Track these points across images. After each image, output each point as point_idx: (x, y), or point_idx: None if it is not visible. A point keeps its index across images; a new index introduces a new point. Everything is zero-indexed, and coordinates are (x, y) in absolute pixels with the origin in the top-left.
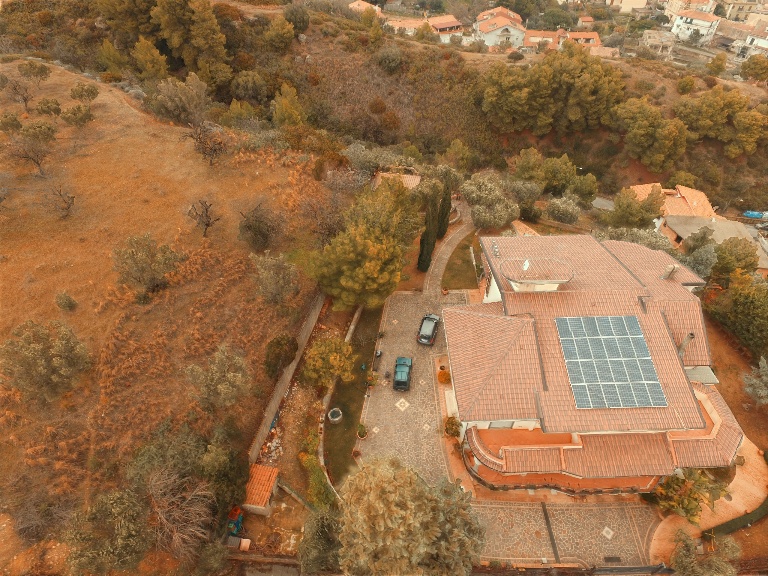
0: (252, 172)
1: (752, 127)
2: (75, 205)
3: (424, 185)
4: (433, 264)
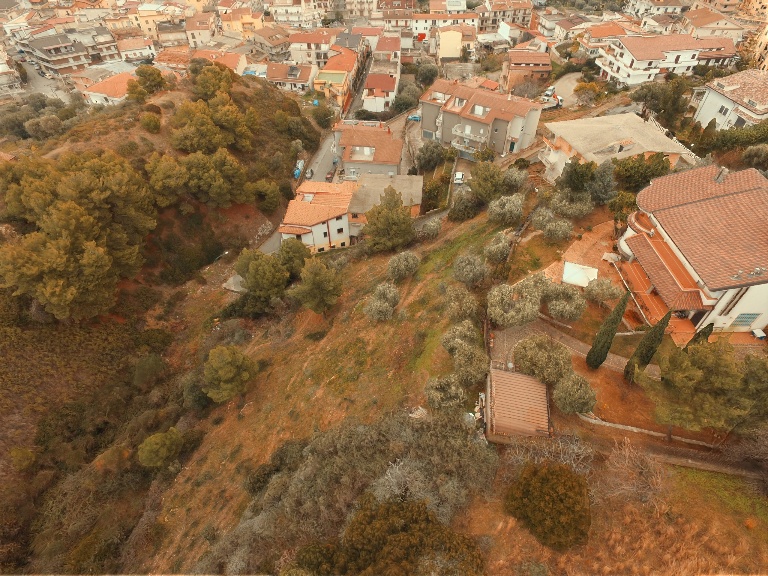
0: None
1: (237, 119)
2: None
3: (546, 357)
4: None
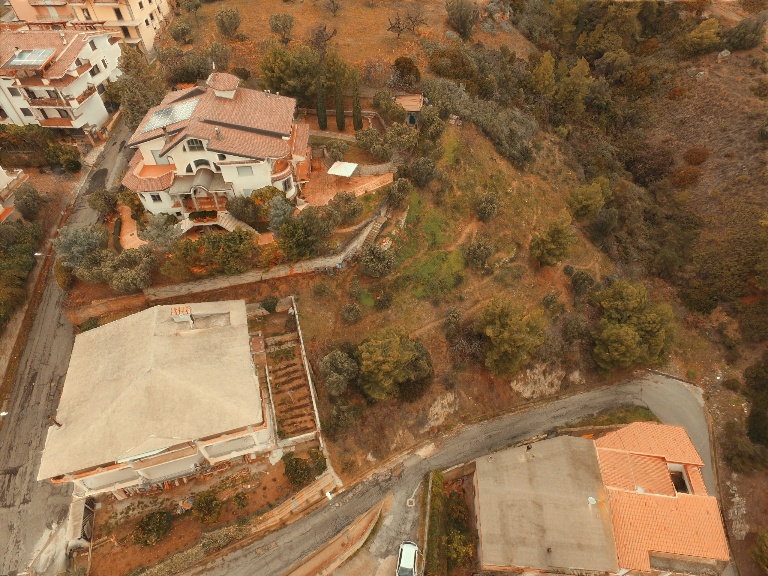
0: (396, 51)
1: None
2: (345, 16)
3: None
4: (330, 132)
